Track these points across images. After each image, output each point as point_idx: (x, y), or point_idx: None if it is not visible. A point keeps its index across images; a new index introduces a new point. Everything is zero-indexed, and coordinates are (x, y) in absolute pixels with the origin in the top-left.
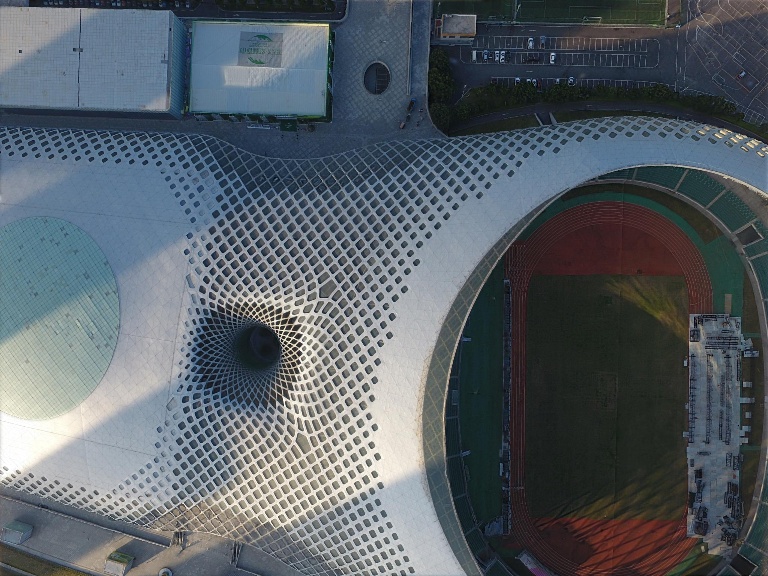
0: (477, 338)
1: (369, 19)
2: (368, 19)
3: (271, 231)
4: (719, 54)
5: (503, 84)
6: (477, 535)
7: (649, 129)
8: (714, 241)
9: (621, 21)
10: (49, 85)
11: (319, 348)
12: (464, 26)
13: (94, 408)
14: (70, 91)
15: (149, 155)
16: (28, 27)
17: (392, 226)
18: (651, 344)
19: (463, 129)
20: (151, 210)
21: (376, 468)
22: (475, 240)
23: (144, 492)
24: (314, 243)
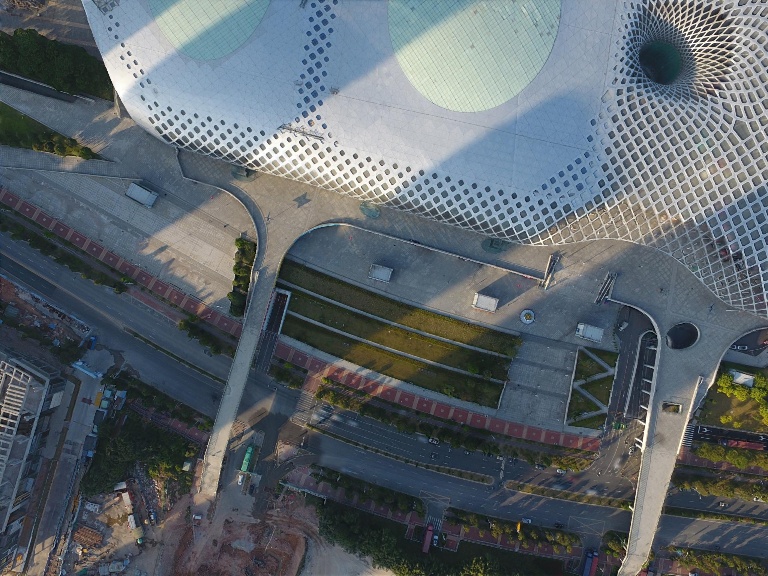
0: None
1: None
2: None
3: None
4: None
5: None
6: None
7: None
8: None
9: None
10: None
11: (759, 36)
12: None
13: (531, 99)
14: None
15: None
16: None
17: None
18: None
19: None
20: None
21: None
22: None
23: (567, 191)
24: None
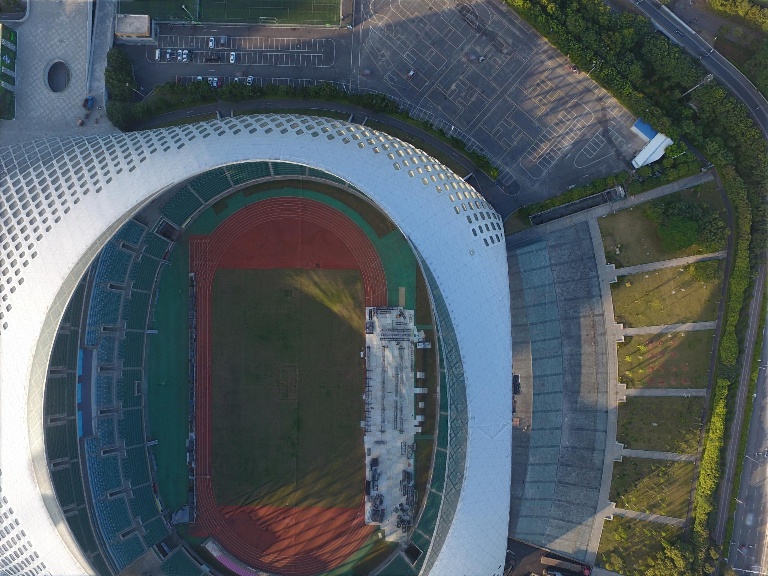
0: (164, 330)
1: (49, 19)
2: (48, 19)
3: None
4: (391, 54)
5: (187, 83)
6: (160, 523)
7: (275, 126)
8: (388, 235)
9: (298, 21)
10: None
11: None
12: (137, 26)
13: None
14: None
15: None
16: None
17: (21, 220)
18: (329, 336)
19: (149, 126)
20: None
21: None
22: (84, 233)
23: None
24: None
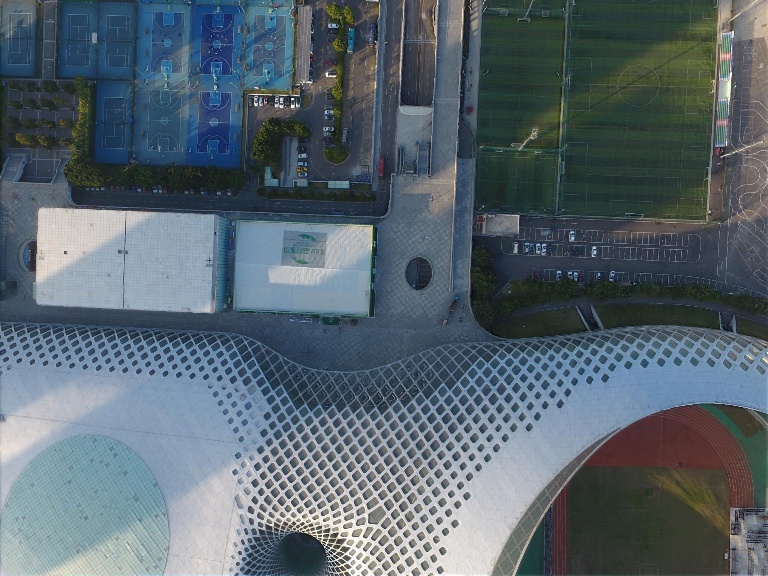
0: None
1: (412, 215)
2: (411, 215)
3: (319, 451)
4: (761, 250)
5: (544, 276)
6: None
7: (697, 354)
8: (755, 435)
9: (663, 216)
10: (94, 286)
11: (368, 575)
12: (507, 225)
13: None
14: (115, 293)
15: (196, 367)
16: (73, 229)
17: (441, 453)
18: (692, 536)
19: (504, 320)
20: (199, 428)
21: None
22: (526, 479)
23: None
24: (363, 466)
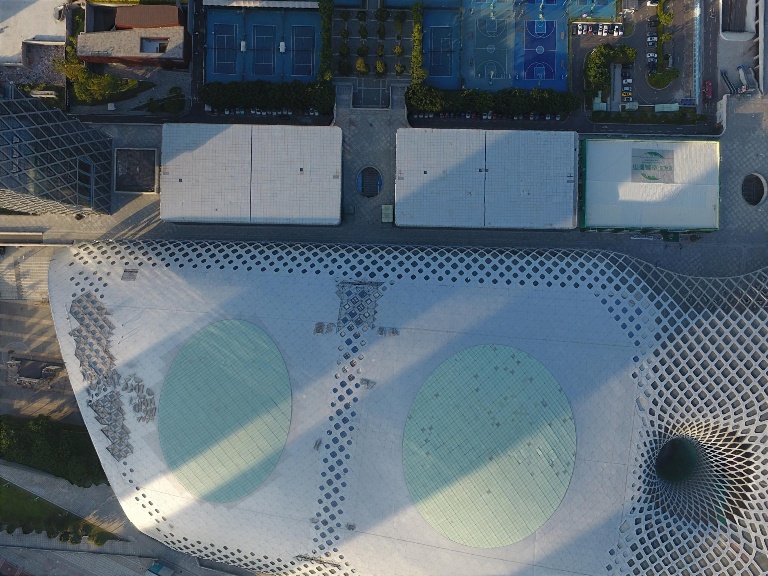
0: None
1: (745, 133)
2: (744, 133)
3: (714, 352)
4: None
5: None
6: None
7: None
8: None
9: None
10: (455, 205)
11: None
12: None
13: (548, 534)
14: (476, 210)
15: (577, 277)
16: (433, 148)
17: None
18: None
19: None
20: (594, 334)
21: None
22: None
23: None
24: (760, 364)
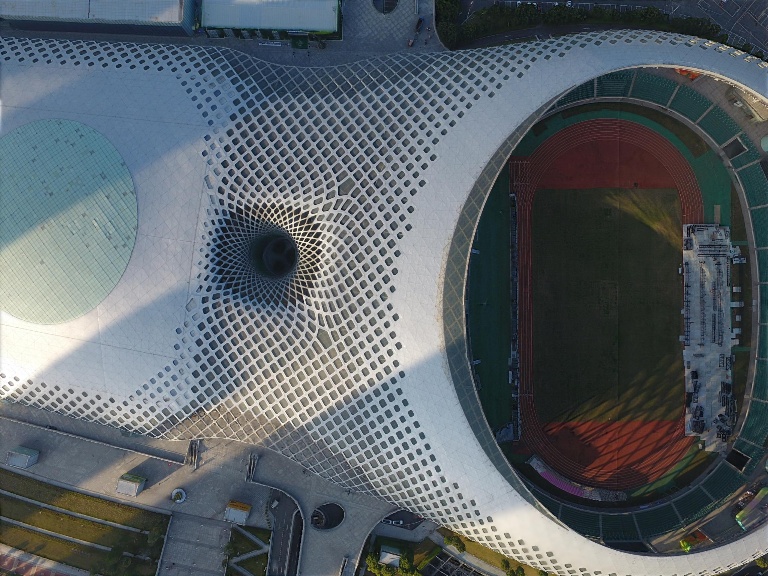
0: (485, 251)
1: None
2: None
3: (289, 133)
4: None
5: None
6: None
7: (646, 37)
8: (703, 155)
9: None
10: None
11: (339, 244)
12: None
13: (111, 310)
14: (80, 2)
15: (164, 62)
16: None
17: (408, 126)
18: (648, 253)
19: None
20: (168, 113)
21: (397, 357)
22: (489, 134)
23: (162, 397)
24: (332, 144)
